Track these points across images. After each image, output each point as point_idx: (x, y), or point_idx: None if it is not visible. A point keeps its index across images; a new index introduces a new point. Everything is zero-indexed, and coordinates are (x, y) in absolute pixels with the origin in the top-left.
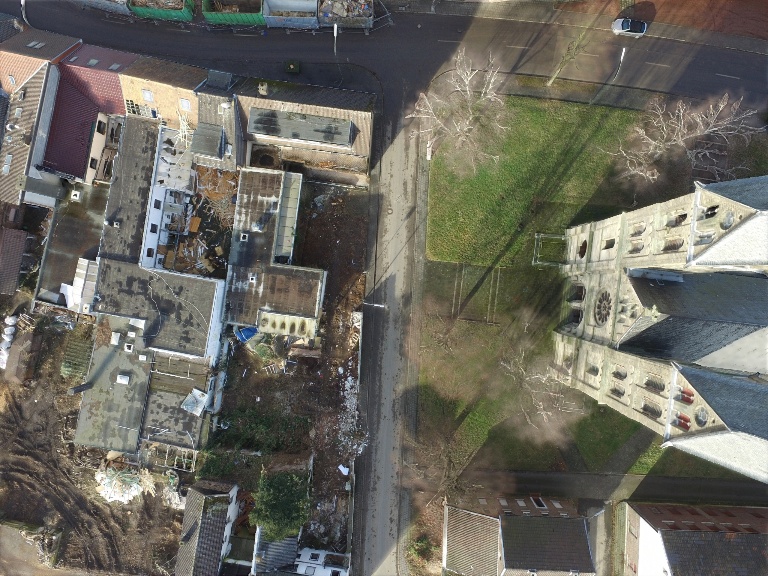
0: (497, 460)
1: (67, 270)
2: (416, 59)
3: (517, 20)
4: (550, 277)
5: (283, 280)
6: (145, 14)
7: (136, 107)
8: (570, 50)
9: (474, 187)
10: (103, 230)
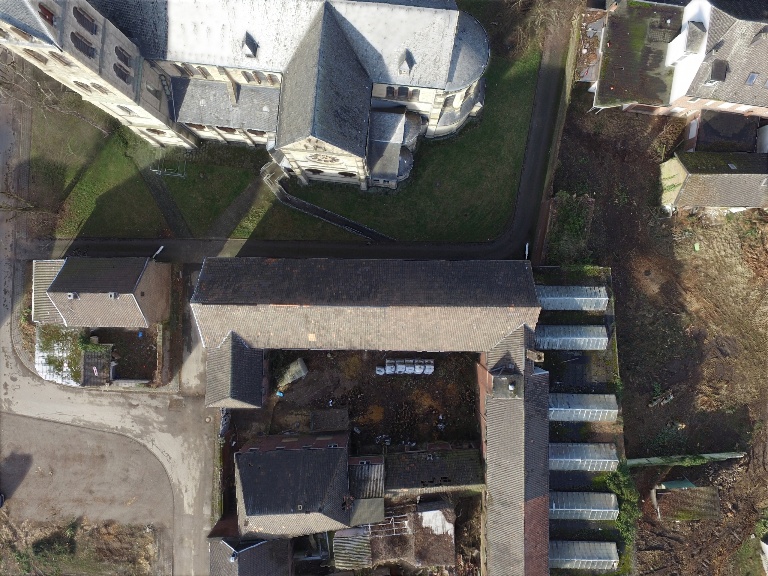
0: (105, 228)
1: None
2: None
3: None
4: None
5: None
6: None
7: None
8: None
9: None
10: None
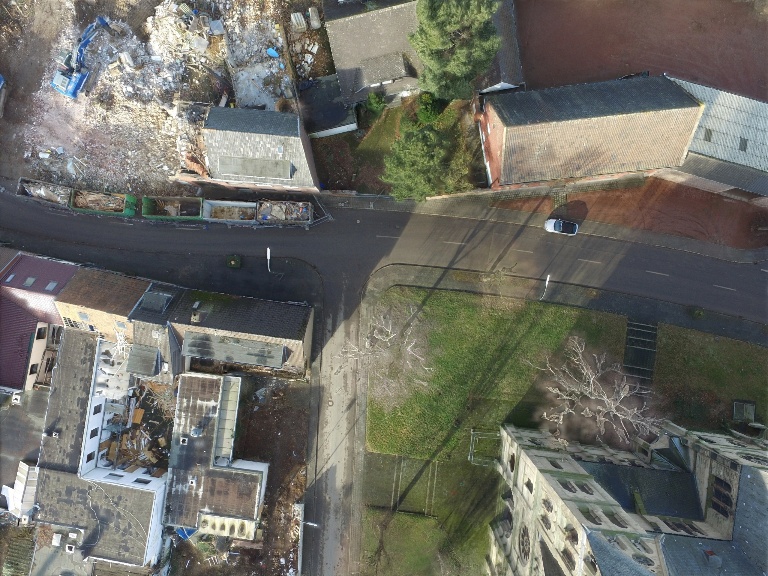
0: None
1: (8, 472)
2: (355, 254)
3: (454, 216)
4: (486, 472)
5: (222, 483)
6: (87, 212)
7: (74, 322)
8: (496, 278)
9: (412, 382)
10: (42, 440)
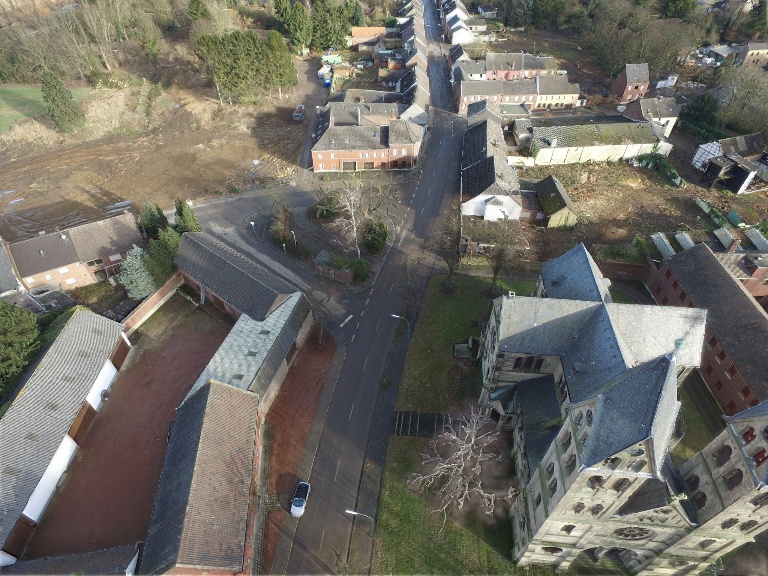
0: None
1: None
2: None
3: None
4: None
5: None
6: None
7: None
8: (346, 574)
9: None
10: None
